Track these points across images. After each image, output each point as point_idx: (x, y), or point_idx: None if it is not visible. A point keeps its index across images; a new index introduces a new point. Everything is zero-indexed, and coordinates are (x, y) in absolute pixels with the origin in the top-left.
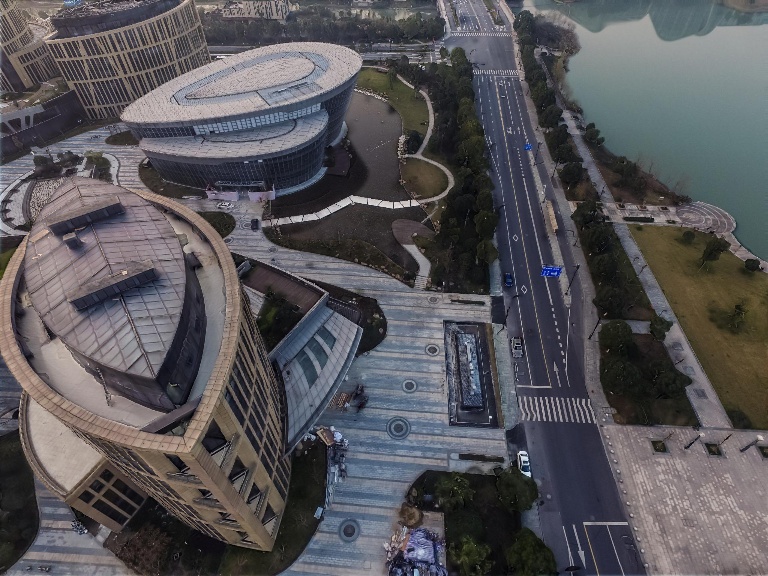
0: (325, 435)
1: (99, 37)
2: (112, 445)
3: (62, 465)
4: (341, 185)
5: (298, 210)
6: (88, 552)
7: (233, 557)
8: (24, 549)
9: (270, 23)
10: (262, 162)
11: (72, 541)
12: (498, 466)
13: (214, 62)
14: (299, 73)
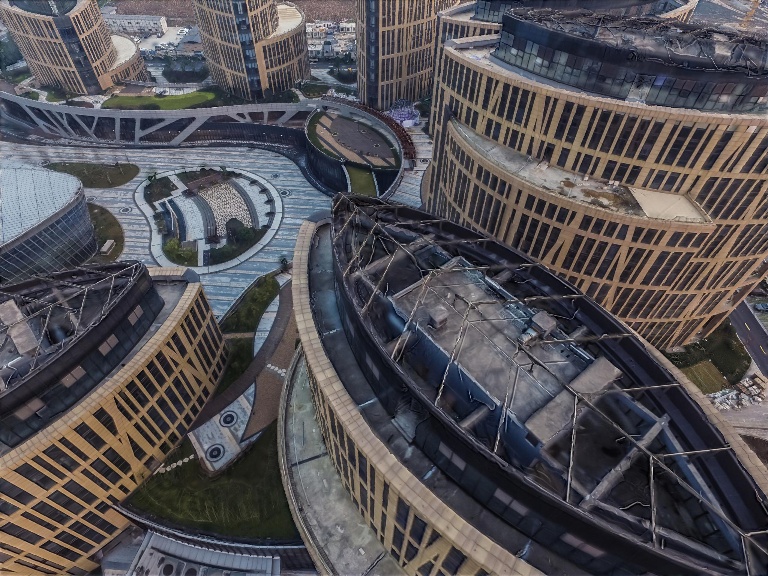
0: None
1: None
2: None
3: None
4: None
5: None
6: None
7: None
8: None
9: None
10: None
11: None
12: None
13: None
14: None
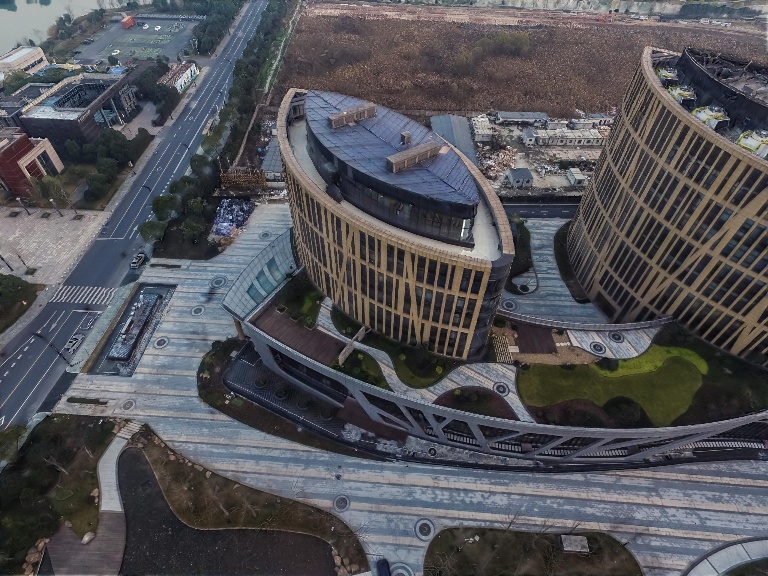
0: None
1: None
2: None
3: None
4: None
5: None
6: None
7: None
8: None
9: None
10: None
11: None
12: (157, 262)
13: None
14: None
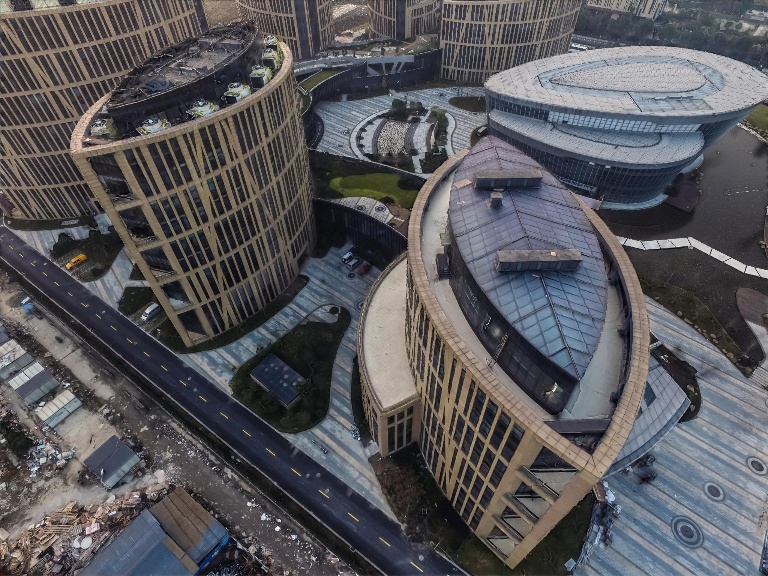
0: (597, 487)
1: (489, 5)
2: (500, 416)
3: (383, 382)
4: (680, 221)
5: (621, 231)
6: (356, 457)
7: (474, 548)
8: (314, 424)
9: (643, 21)
10: (609, 169)
11: (347, 440)
12: None
13: (586, 51)
14: (684, 84)
